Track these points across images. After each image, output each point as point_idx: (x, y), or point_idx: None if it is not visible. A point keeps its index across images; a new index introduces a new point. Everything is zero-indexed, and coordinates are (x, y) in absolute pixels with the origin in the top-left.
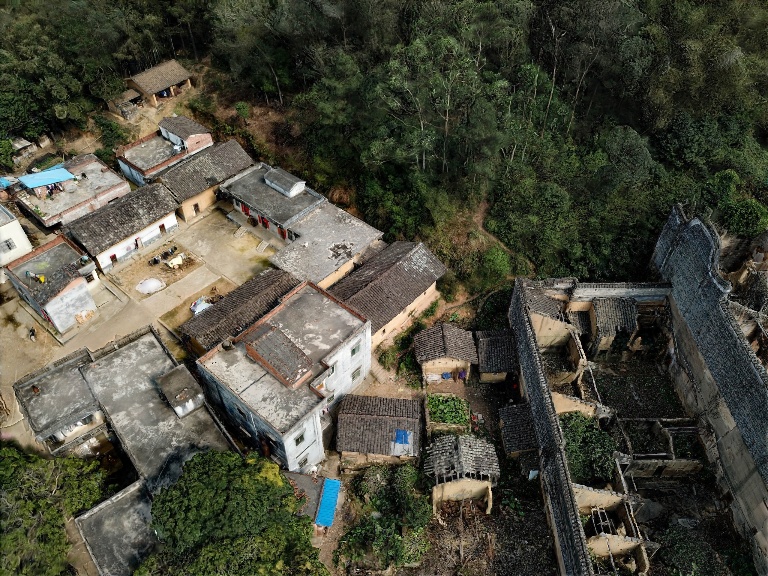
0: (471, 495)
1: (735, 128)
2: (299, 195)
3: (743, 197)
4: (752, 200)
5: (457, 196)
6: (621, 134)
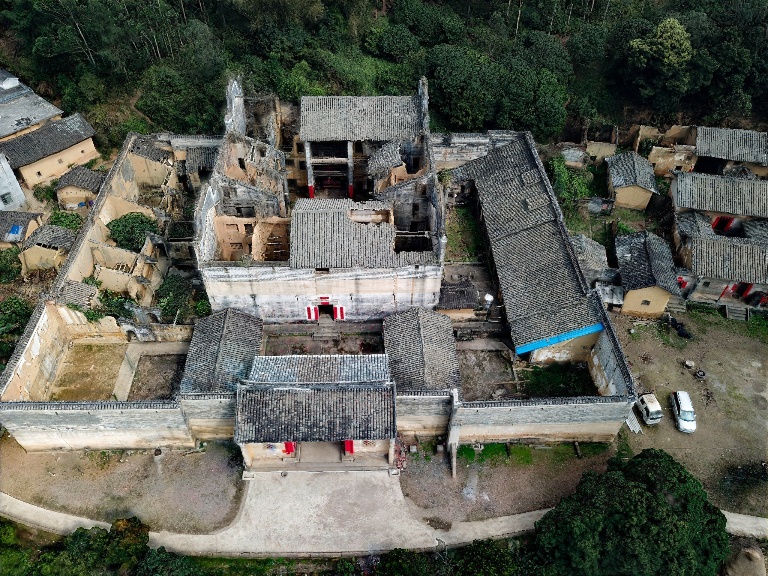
0: (52, 264)
1: (325, 34)
2: (13, 88)
3: (332, 86)
4: (300, 77)
5: (119, 84)
6: (193, 25)
